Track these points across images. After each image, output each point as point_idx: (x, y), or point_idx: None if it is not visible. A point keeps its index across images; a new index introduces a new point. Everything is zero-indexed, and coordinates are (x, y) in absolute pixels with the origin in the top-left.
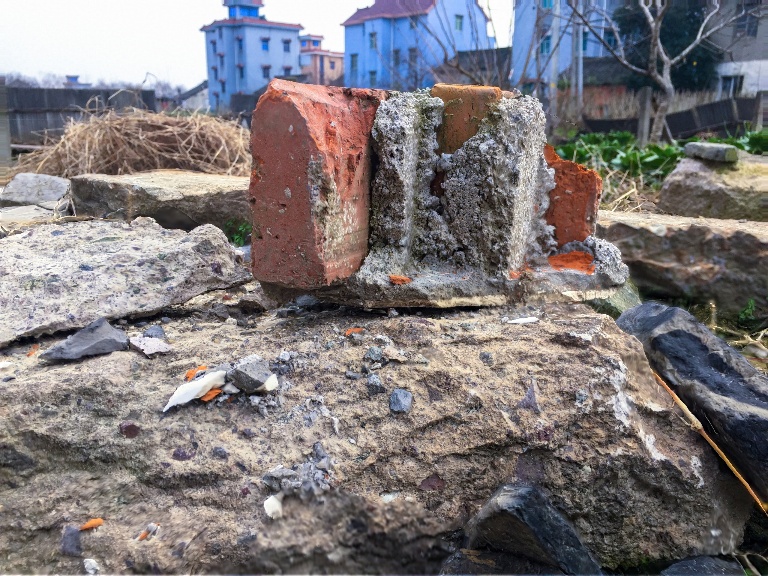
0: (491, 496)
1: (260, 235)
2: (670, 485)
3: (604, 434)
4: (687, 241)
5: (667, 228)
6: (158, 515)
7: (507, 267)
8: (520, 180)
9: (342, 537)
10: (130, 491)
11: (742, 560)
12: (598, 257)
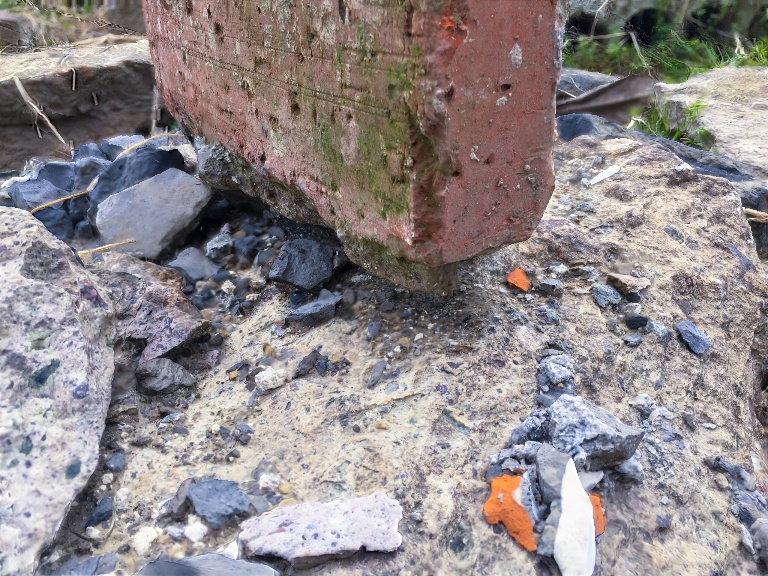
0: None
1: (456, 168)
2: None
3: None
4: None
5: None
6: None
7: None
8: None
9: None
10: None
11: None
12: None
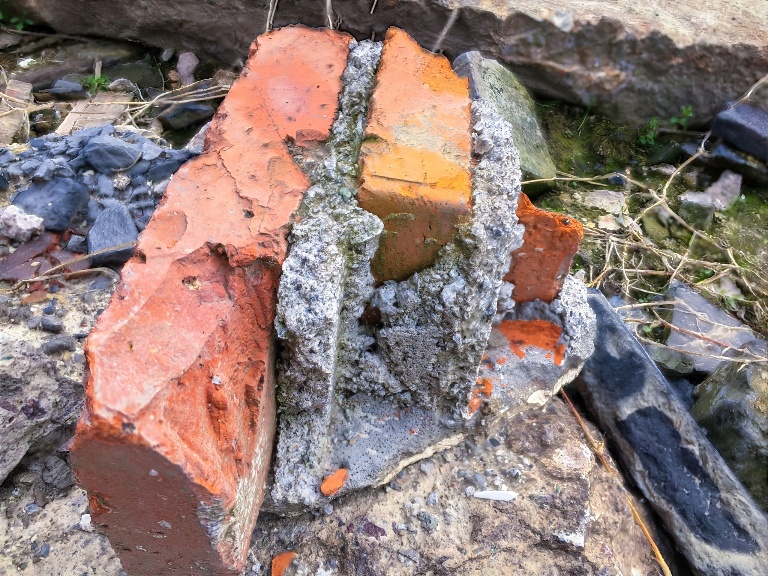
0: None
1: (125, 548)
2: None
3: None
4: (594, 39)
5: (574, 21)
6: None
7: (467, 404)
8: None
9: None
10: None
11: None
12: (568, 331)
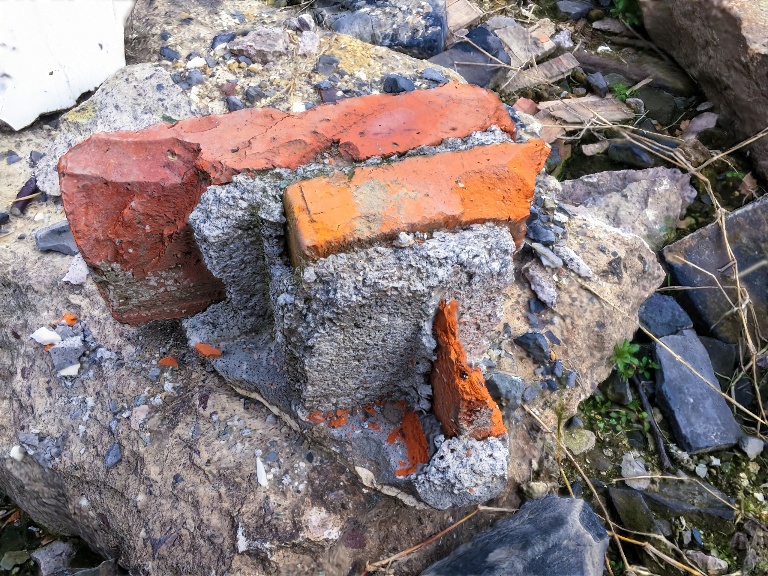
0: None
1: None
2: None
3: None
4: None
5: None
6: (1, 397)
7: (305, 408)
8: (322, 352)
9: (54, 496)
10: (4, 370)
11: None
12: None
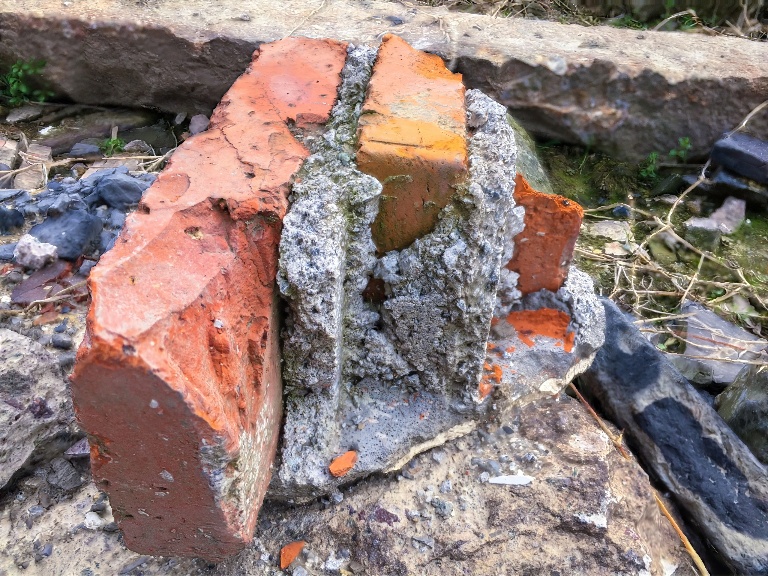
0: None
1: (127, 514)
2: None
3: None
4: (589, 80)
5: (568, 65)
6: None
7: (477, 387)
8: None
9: None
10: None
11: None
12: (577, 318)
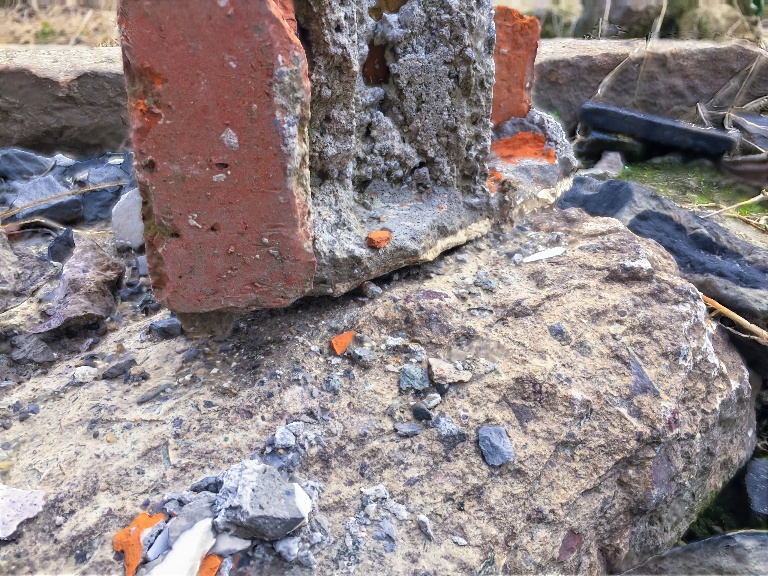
0: (691, 549)
1: (174, 231)
2: (734, 408)
3: (704, 386)
4: None
5: None
6: None
7: (486, 178)
8: None
9: None
10: None
11: (767, 448)
12: (551, 136)
